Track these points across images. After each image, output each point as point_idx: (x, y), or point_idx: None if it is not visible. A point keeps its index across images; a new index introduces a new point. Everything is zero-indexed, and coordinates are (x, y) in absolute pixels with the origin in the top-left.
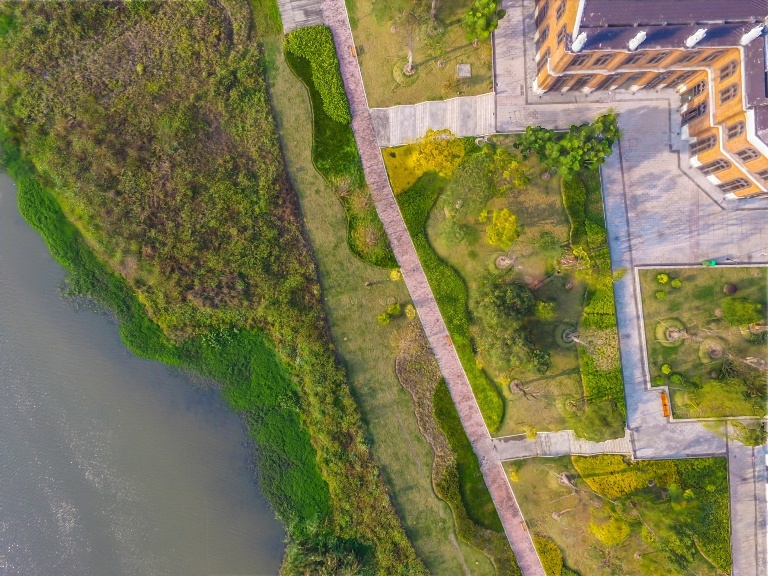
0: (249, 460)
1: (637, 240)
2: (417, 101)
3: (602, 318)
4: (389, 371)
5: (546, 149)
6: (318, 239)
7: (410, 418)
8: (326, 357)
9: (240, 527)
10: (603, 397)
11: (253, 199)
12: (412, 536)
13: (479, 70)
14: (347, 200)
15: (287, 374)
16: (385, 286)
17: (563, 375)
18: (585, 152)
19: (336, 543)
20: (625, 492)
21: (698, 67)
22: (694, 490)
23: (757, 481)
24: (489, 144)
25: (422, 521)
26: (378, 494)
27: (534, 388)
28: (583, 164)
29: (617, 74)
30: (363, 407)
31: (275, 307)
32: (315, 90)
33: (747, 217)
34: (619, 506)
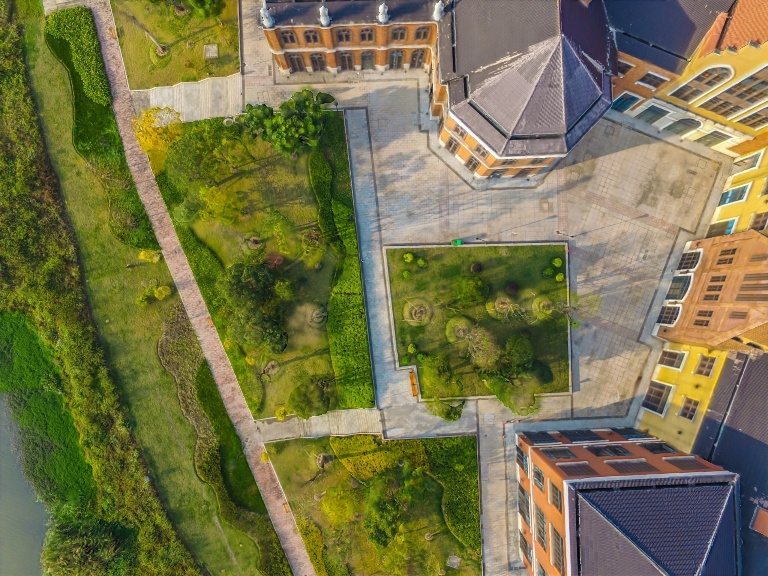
0: (12, 443)
1: (386, 220)
2: (174, 82)
3: (349, 298)
4: (151, 353)
5: (266, 127)
6: (79, 221)
7: (172, 400)
8: (84, 339)
9: (3, 511)
10: (351, 377)
11: (9, 181)
12: (175, 519)
13: (226, 50)
14: (108, 182)
15: (49, 357)
16: (147, 268)
17: (315, 355)
18: (287, 128)
19: (97, 526)
20: (377, 472)
21: (420, 45)
22: (442, 469)
23: (508, 460)
24: (235, 124)
25: (185, 504)
26: (138, 477)
27: (290, 369)
28: (301, 142)
29: (345, 52)
30: (125, 389)
31: (32, 289)
32: (75, 72)
33: (497, 197)
34: (373, 486)
